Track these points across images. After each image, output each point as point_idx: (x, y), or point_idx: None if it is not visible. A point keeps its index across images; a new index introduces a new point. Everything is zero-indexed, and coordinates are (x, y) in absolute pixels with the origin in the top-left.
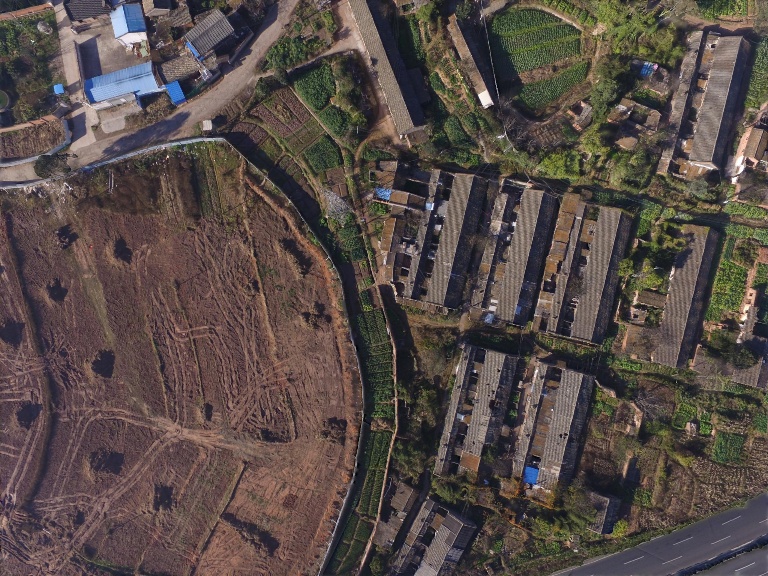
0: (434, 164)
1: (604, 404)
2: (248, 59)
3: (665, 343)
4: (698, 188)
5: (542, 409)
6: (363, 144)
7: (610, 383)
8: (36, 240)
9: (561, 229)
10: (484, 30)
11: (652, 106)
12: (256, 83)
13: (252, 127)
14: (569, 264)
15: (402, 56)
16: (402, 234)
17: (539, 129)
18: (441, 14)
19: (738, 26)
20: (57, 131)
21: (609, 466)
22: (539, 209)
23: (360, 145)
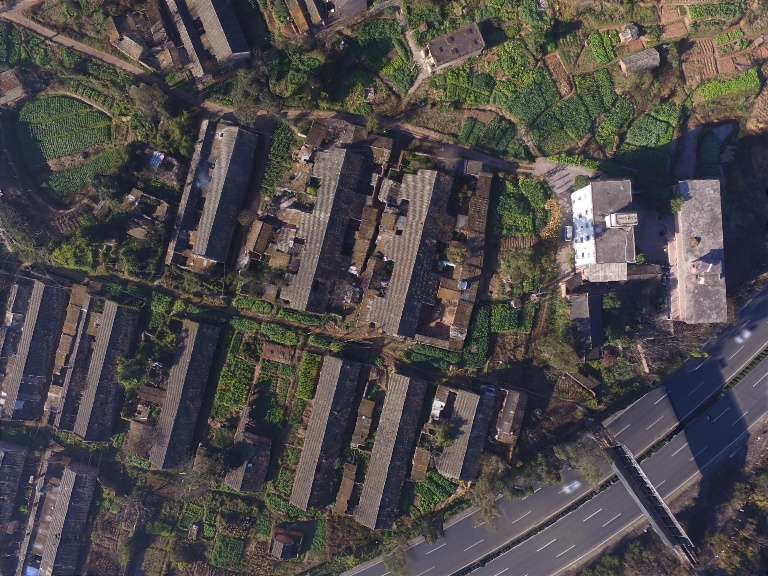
0: None
1: (111, 502)
2: None
3: (157, 443)
4: (189, 283)
5: (44, 507)
6: None
7: (119, 480)
8: None
9: (69, 321)
10: (15, 117)
11: (162, 196)
12: None
13: None
14: (74, 358)
15: None
16: None
17: (61, 217)
18: None
19: (258, 113)
20: None
21: (111, 568)
22: (40, 302)
23: None
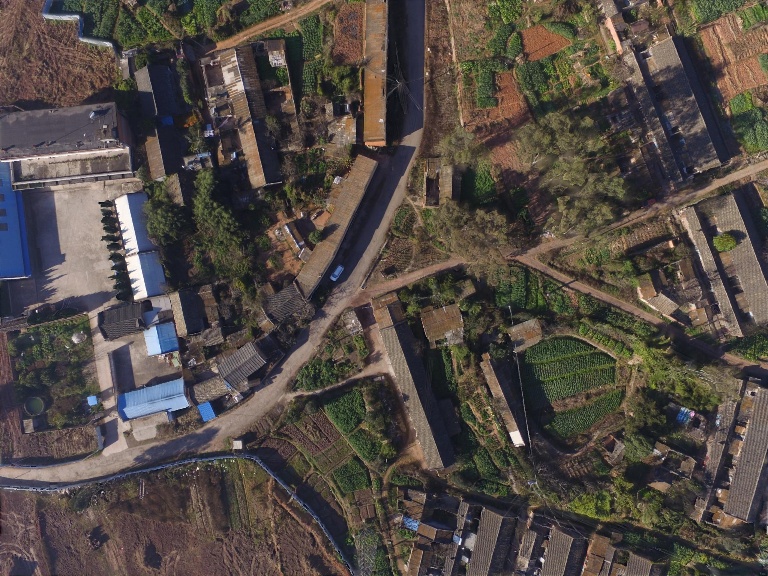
0: (462, 493)
1: None
2: (279, 377)
3: None
4: (732, 547)
5: None
6: (392, 468)
7: None
8: (68, 539)
9: (589, 571)
10: None
11: (687, 451)
12: (286, 402)
13: (281, 443)
14: None
15: (433, 384)
16: (429, 565)
17: (570, 462)
18: (474, 351)
19: None
20: (90, 435)
21: None
22: (568, 555)
23: (389, 469)
